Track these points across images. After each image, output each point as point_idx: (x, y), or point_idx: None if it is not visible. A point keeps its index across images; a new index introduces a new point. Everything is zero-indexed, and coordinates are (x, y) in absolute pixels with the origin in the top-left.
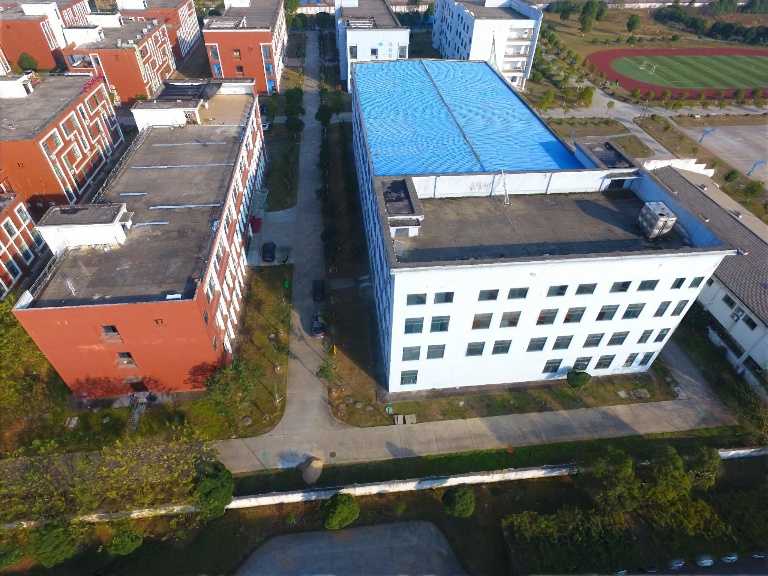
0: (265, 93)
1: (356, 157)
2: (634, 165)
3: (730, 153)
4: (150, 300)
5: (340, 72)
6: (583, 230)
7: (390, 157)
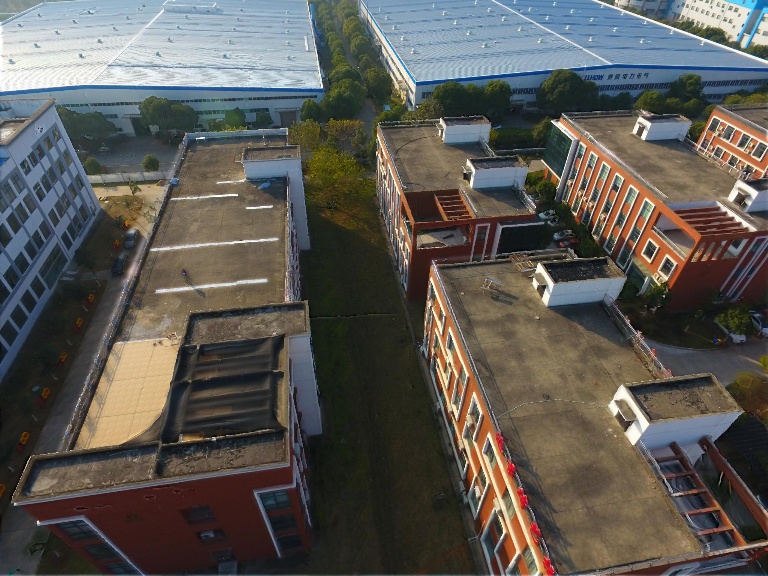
0: None
1: None
2: None
3: None
4: (217, 142)
5: None
6: None
7: None
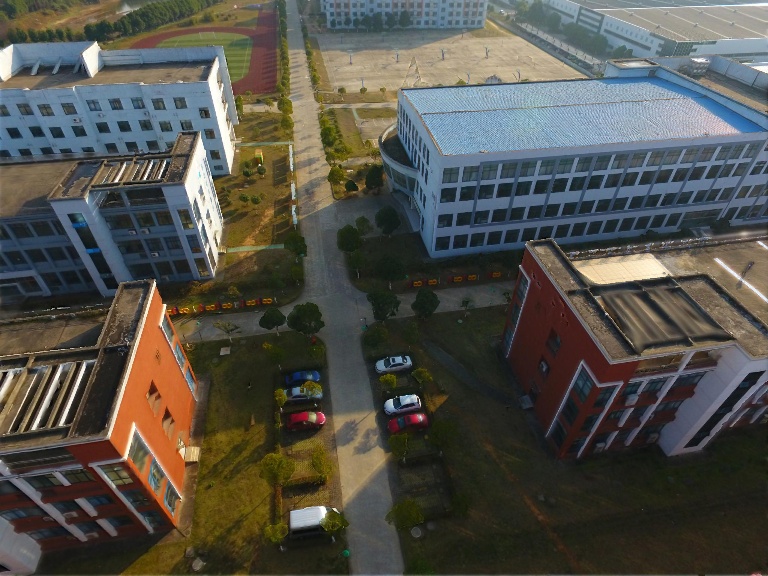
0: (192, 406)
1: (502, 238)
2: (644, 59)
3: (381, 86)
4: None
5: (117, 285)
6: (714, 87)
7: (706, 129)
